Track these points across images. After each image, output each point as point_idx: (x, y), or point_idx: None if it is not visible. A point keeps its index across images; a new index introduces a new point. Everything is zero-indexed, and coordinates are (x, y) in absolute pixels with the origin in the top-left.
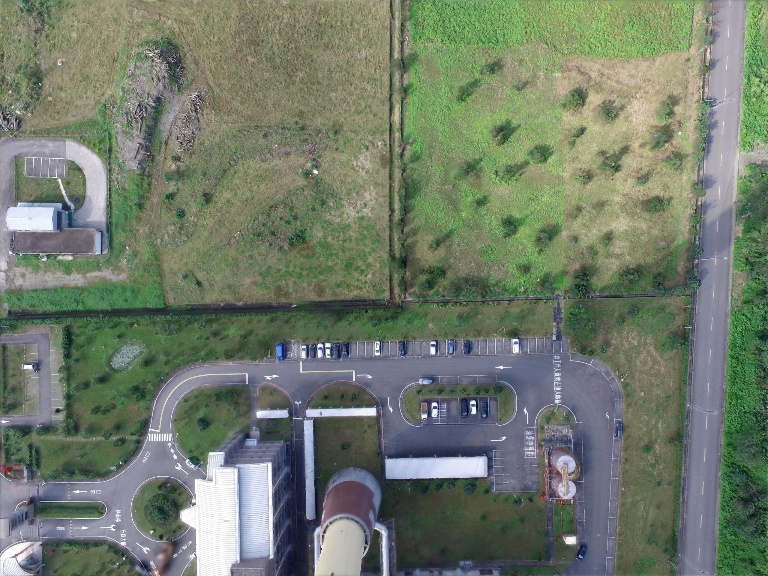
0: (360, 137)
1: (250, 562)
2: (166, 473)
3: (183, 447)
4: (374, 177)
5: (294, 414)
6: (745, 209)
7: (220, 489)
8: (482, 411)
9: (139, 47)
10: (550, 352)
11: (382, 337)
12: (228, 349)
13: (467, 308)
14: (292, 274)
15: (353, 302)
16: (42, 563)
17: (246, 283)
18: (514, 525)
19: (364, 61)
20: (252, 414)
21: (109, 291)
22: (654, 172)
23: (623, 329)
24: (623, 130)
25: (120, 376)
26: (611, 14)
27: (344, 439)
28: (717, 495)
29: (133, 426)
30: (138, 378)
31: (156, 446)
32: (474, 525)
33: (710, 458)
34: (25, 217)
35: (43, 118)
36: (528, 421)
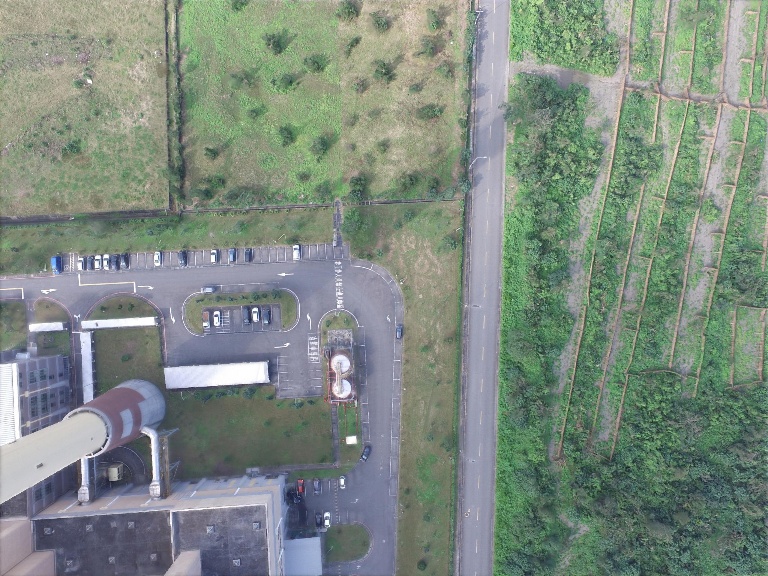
0: (135, 46)
1: None
2: None
3: None
4: (150, 87)
5: (73, 328)
6: (509, 113)
7: None
8: (264, 318)
9: None
10: (331, 258)
11: (162, 247)
12: None
13: (247, 216)
14: (67, 185)
15: (133, 213)
16: None
17: (18, 195)
18: (299, 430)
19: None
20: None
21: None
22: (428, 81)
23: (401, 234)
24: (397, 40)
25: None
26: None
27: (125, 351)
28: (495, 392)
29: None
30: None
31: None
32: (260, 432)
33: (488, 356)
34: None
35: None
36: (311, 327)
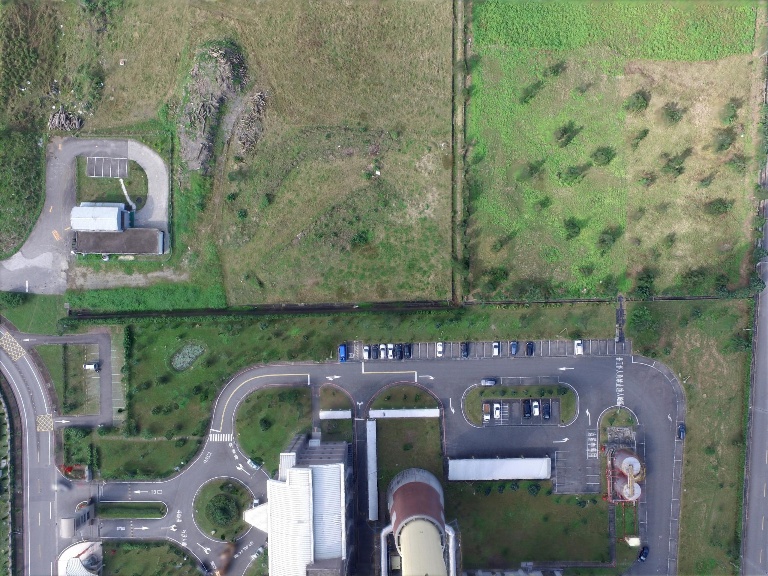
0: (423, 138)
1: (324, 563)
2: (227, 473)
3: (244, 447)
4: (437, 178)
5: (356, 415)
6: None
7: (294, 490)
8: (545, 412)
9: (203, 47)
10: (612, 354)
11: (444, 338)
12: (291, 350)
13: (529, 309)
14: (354, 275)
15: (415, 303)
16: (102, 563)
17: (308, 284)
18: (576, 526)
19: (427, 62)
20: (314, 415)
21: (171, 291)
22: (717, 174)
23: (685, 331)
24: (686, 132)
25: (182, 376)
26: (674, 17)
27: (406, 440)
28: None
29: (194, 426)
30: (200, 378)
31: (217, 446)
32: (536, 526)
33: None
34: (90, 217)
35: (105, 118)
36: (590, 423)
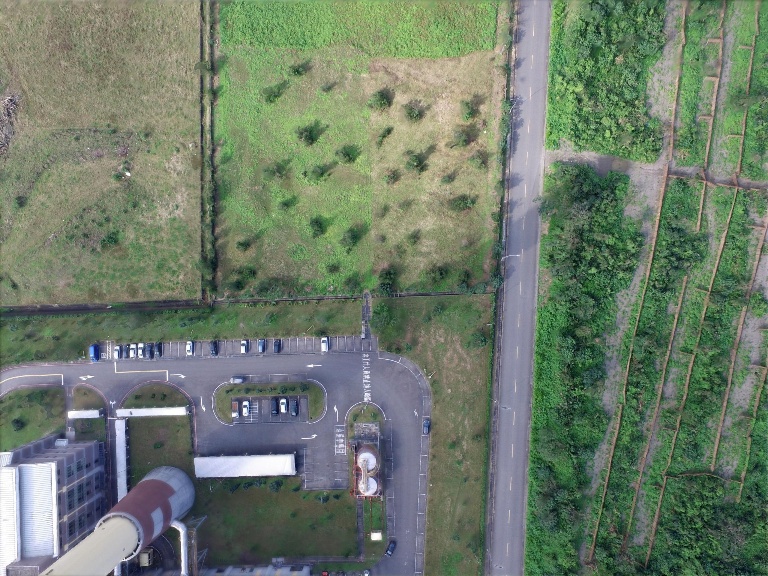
0: (171, 139)
1: (29, 560)
2: None
3: (0, 448)
4: (185, 179)
5: (109, 414)
6: (544, 207)
7: None
8: (291, 409)
9: None
10: (359, 350)
11: (194, 337)
12: (39, 350)
13: (277, 307)
14: (105, 275)
15: (167, 303)
16: None
17: (60, 285)
18: (324, 522)
19: (175, 64)
20: None
21: None
22: (460, 171)
23: (430, 327)
24: (430, 129)
25: None
26: (416, 14)
27: (158, 438)
28: (525, 490)
29: None
30: None
31: None
32: (286, 522)
33: (518, 454)
34: None
35: None
36: (338, 419)
